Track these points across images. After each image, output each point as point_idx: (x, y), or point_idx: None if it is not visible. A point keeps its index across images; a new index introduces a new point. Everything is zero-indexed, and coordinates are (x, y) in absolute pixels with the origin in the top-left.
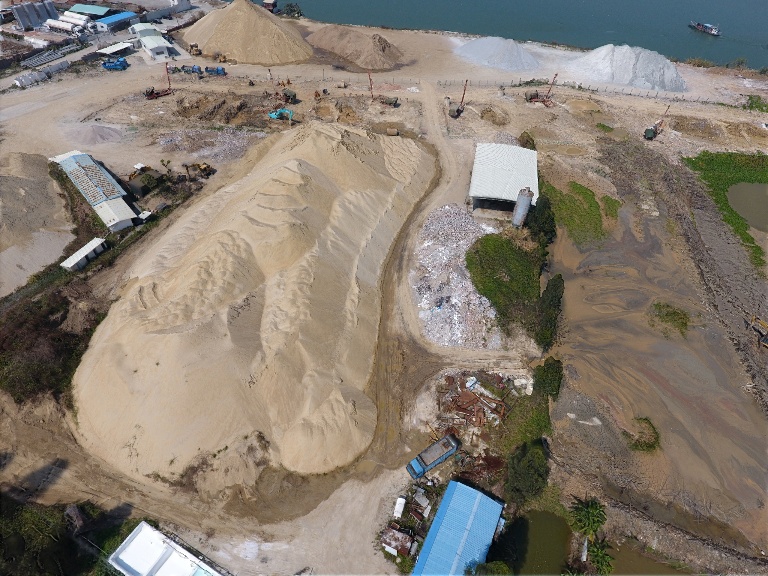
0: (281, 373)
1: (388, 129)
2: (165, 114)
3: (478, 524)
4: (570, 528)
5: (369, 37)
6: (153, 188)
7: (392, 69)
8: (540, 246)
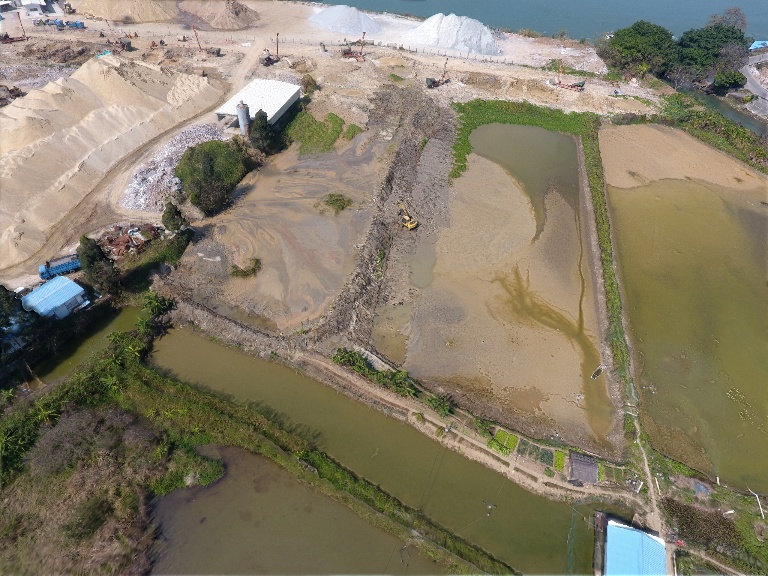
0: None
1: (195, 70)
2: (10, 54)
3: (55, 296)
4: None
5: (224, 2)
6: None
7: (240, 29)
8: (262, 153)
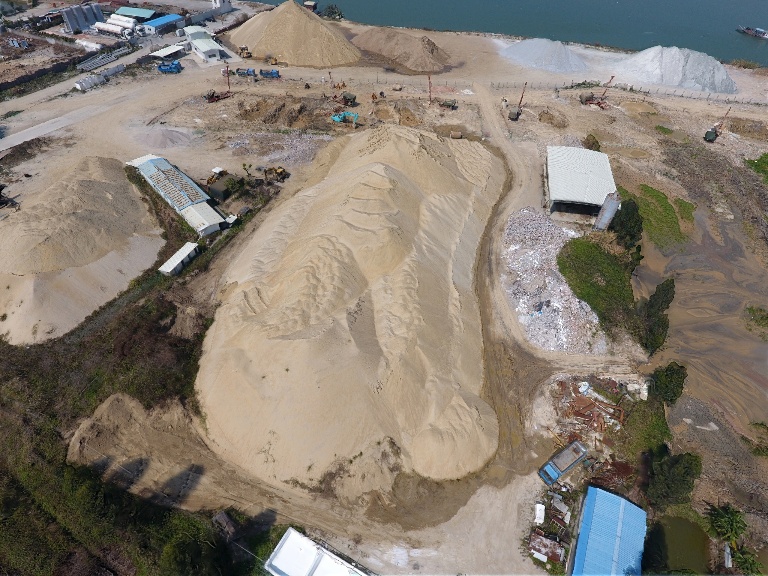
0: (406, 379)
1: (452, 132)
2: (229, 117)
3: (627, 531)
4: (706, 534)
5: (418, 39)
6: (233, 192)
7: (442, 71)
8: (625, 250)
